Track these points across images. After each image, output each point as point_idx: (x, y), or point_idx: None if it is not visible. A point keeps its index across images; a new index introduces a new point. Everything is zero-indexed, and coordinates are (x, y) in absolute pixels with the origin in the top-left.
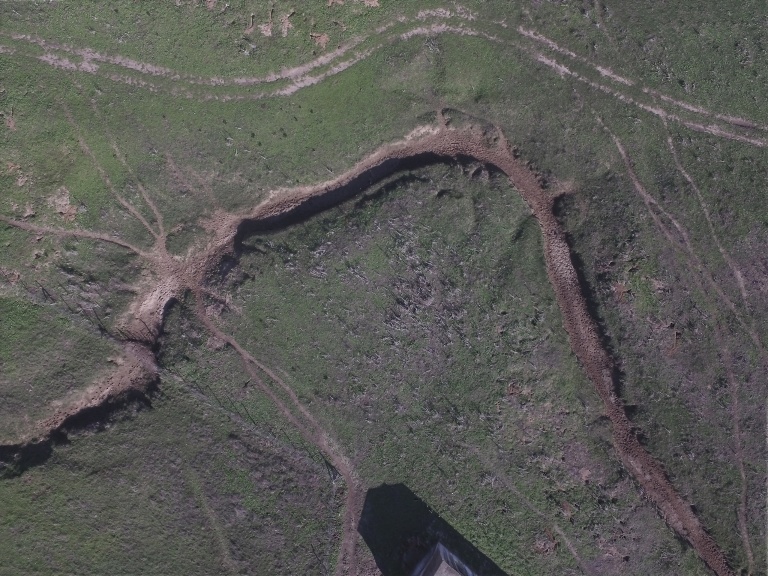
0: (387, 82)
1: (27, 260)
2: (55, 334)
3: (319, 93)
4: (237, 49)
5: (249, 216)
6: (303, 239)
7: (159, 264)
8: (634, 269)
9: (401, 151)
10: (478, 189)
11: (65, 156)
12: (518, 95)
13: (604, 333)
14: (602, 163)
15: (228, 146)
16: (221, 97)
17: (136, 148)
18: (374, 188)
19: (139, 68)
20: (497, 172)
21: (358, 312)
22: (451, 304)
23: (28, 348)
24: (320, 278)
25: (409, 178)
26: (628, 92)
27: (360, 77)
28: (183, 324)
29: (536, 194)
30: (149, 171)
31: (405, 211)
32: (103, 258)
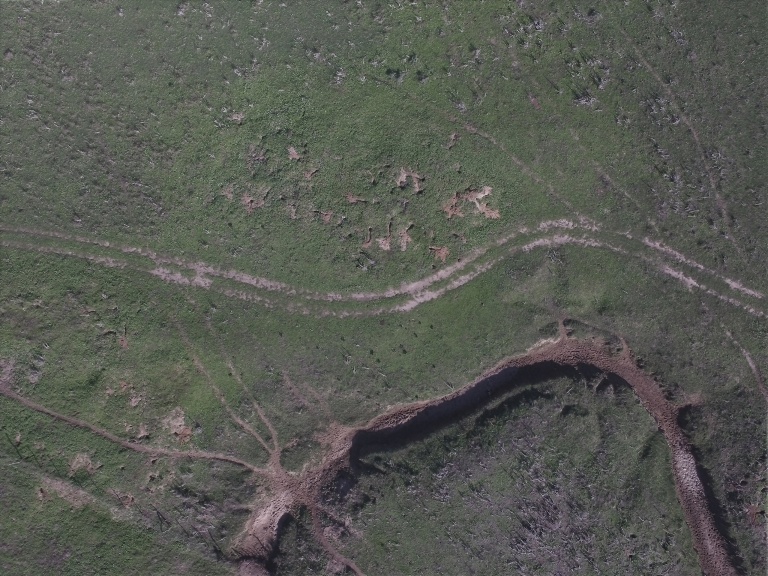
0: (508, 295)
1: (141, 483)
2: (170, 558)
3: (439, 308)
4: (355, 264)
5: (364, 427)
6: (424, 459)
7: (273, 479)
8: (767, 489)
9: (520, 359)
10: (603, 405)
11: (179, 375)
12: (644, 308)
13: (736, 554)
14: (731, 377)
15: (347, 364)
16: (339, 313)
17: (252, 366)
18: (495, 403)
19: (253, 282)
20: (622, 386)
21: (482, 536)
22: (578, 527)
23: (143, 573)
24: (443, 501)
25: (532, 393)
26: (758, 305)
27: (481, 291)
28: (301, 546)
29: (660, 404)
30: (265, 389)
31: (530, 431)
32: (218, 478)
